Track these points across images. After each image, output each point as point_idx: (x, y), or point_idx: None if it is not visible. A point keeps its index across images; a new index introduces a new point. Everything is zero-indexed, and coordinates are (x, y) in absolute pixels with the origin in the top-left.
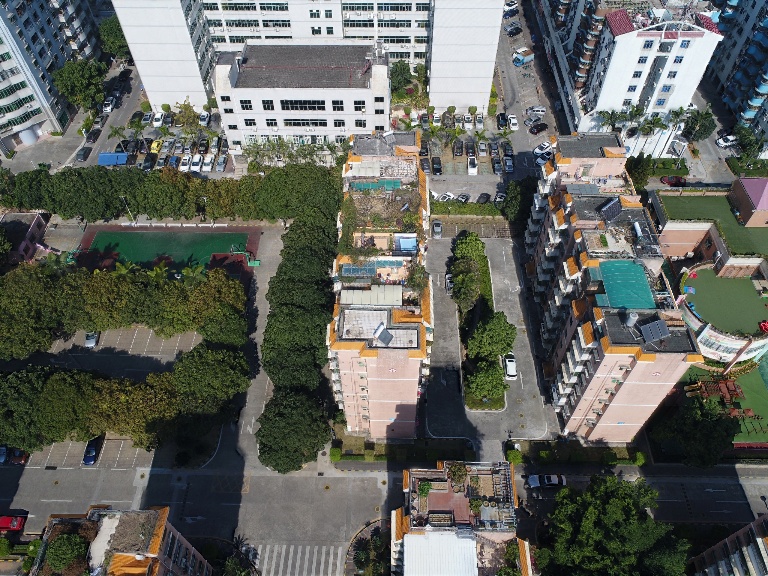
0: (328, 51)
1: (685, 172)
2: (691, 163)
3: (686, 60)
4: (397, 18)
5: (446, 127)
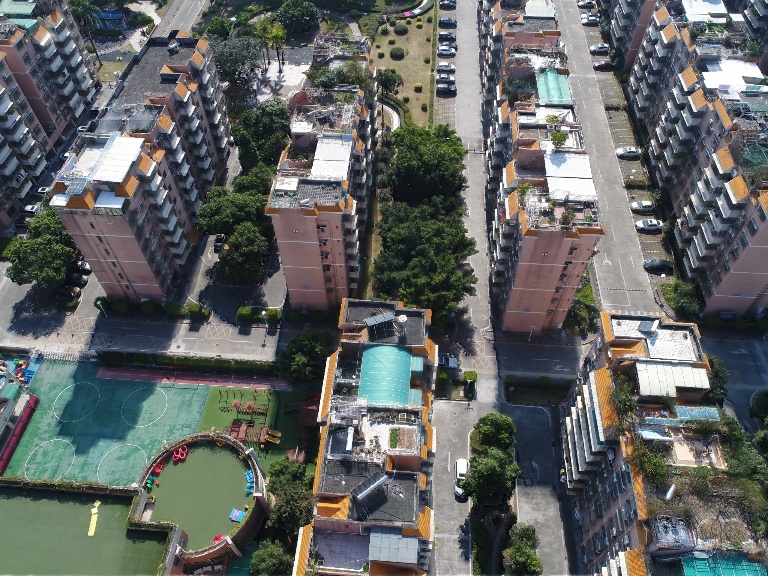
0: None
1: None
2: None
3: None
4: None
5: None
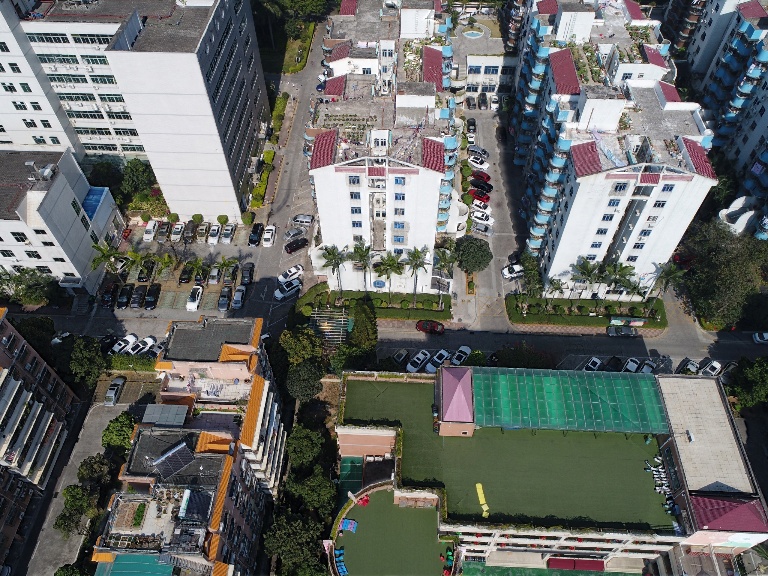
0: (10, 159)
1: (446, 316)
2: (462, 301)
3: (409, 197)
4: None
5: (184, 241)
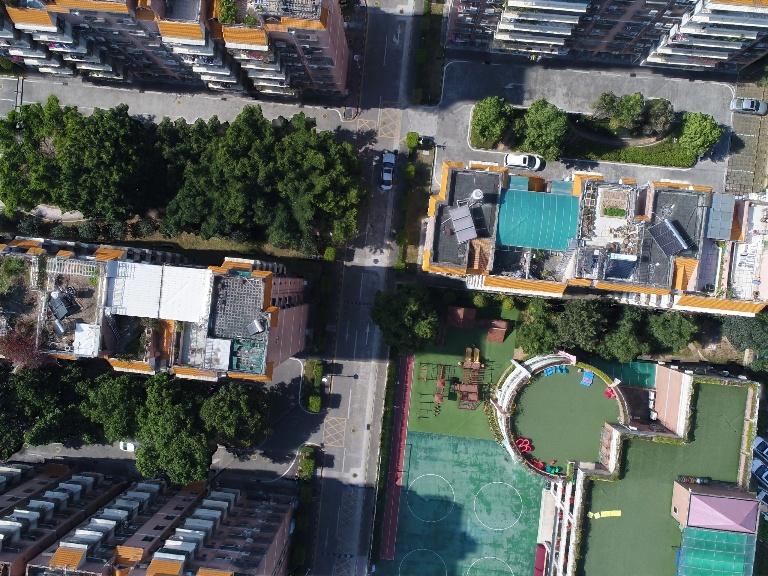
0: None
1: None
2: None
3: None
4: None
5: None
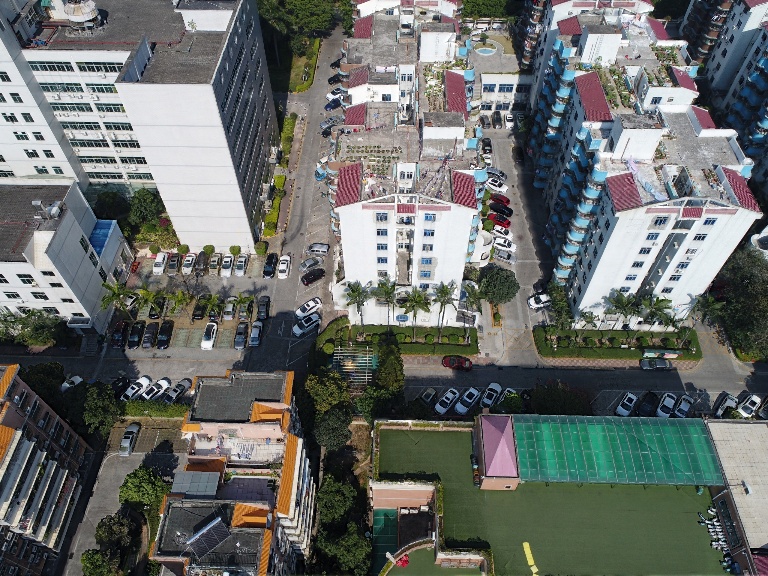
0: (13, 195)
1: (473, 351)
2: (488, 333)
3: (439, 233)
4: (134, 138)
5: (196, 274)
